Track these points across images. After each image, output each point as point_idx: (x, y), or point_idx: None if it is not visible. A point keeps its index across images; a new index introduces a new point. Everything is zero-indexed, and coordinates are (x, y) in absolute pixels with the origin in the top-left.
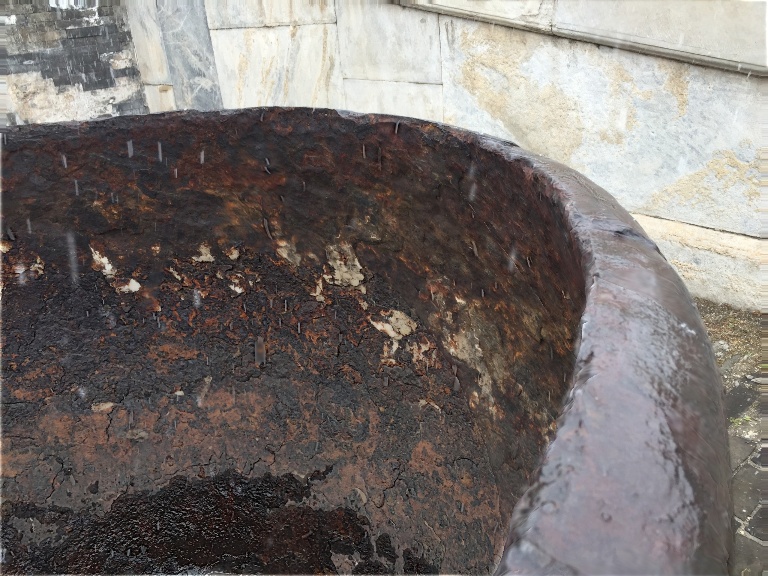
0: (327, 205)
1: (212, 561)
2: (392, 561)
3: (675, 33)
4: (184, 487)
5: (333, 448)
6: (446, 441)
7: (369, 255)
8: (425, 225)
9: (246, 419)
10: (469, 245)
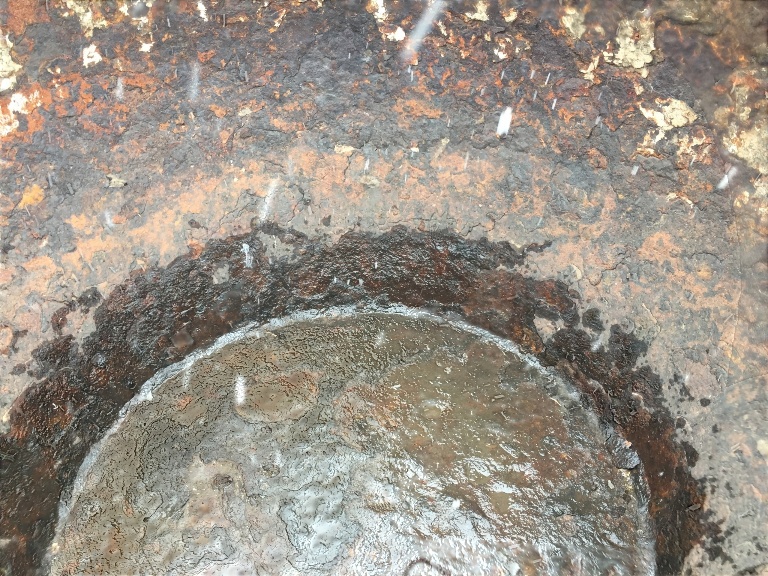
0: None
1: (421, 303)
2: (597, 332)
3: None
4: (404, 236)
5: (556, 225)
6: (690, 235)
7: (671, 36)
8: None
9: (474, 185)
10: None
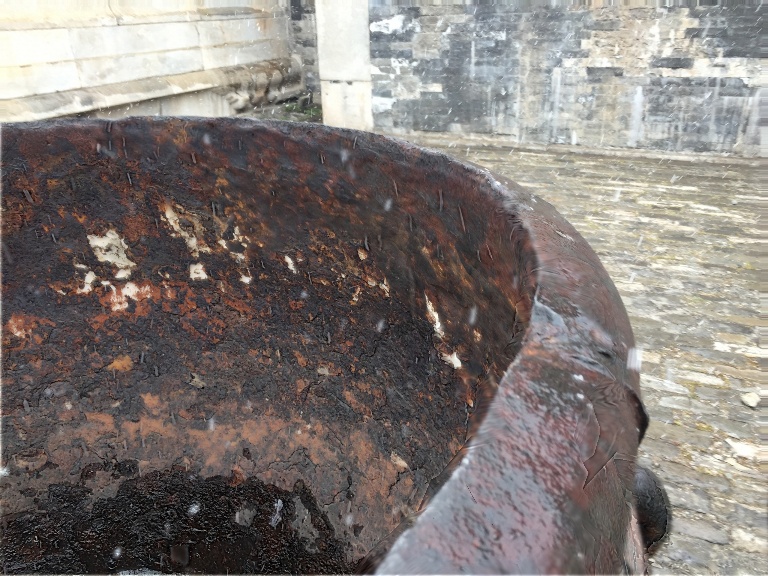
0: None
1: None
2: None
3: None
4: None
5: None
6: None
7: None
8: None
9: None
10: None
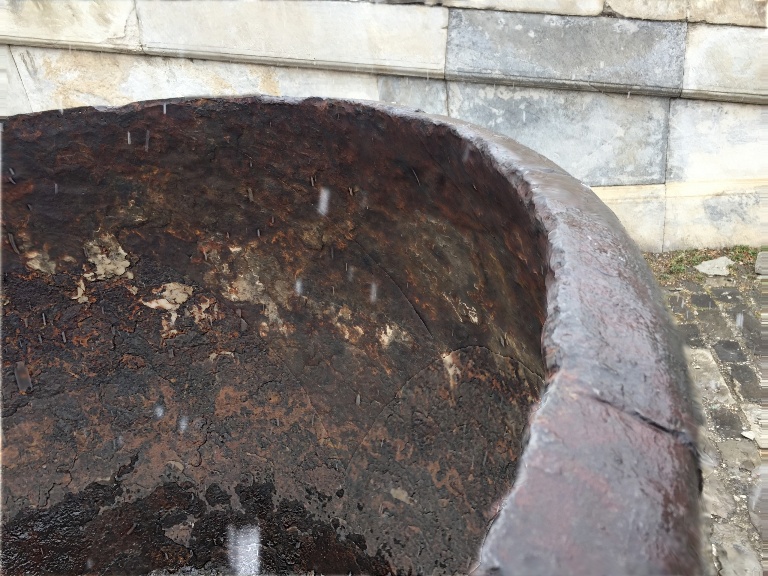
0: (84, 201)
1: None
2: (227, 503)
3: (257, 42)
4: None
5: (132, 438)
6: (246, 377)
7: (133, 239)
8: (196, 191)
9: (25, 452)
10: (244, 194)
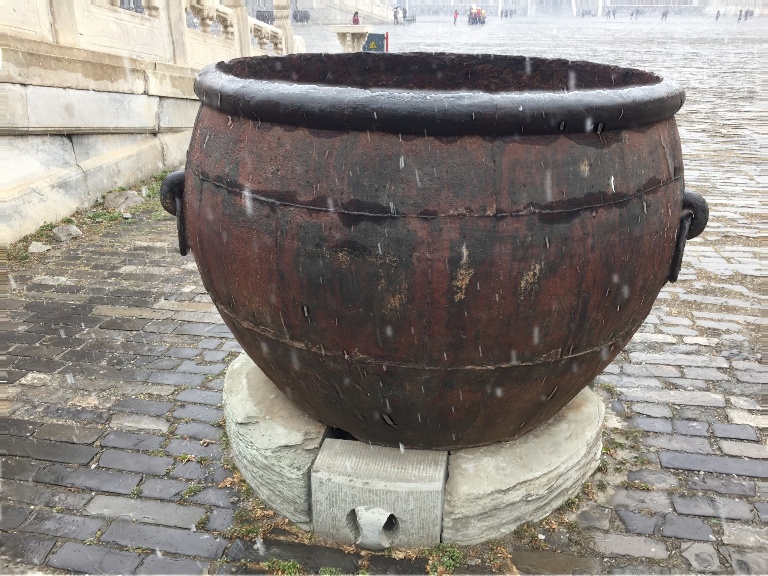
0: None
1: None
2: None
3: None
4: None
5: None
6: None
7: None
8: None
9: None
10: None
